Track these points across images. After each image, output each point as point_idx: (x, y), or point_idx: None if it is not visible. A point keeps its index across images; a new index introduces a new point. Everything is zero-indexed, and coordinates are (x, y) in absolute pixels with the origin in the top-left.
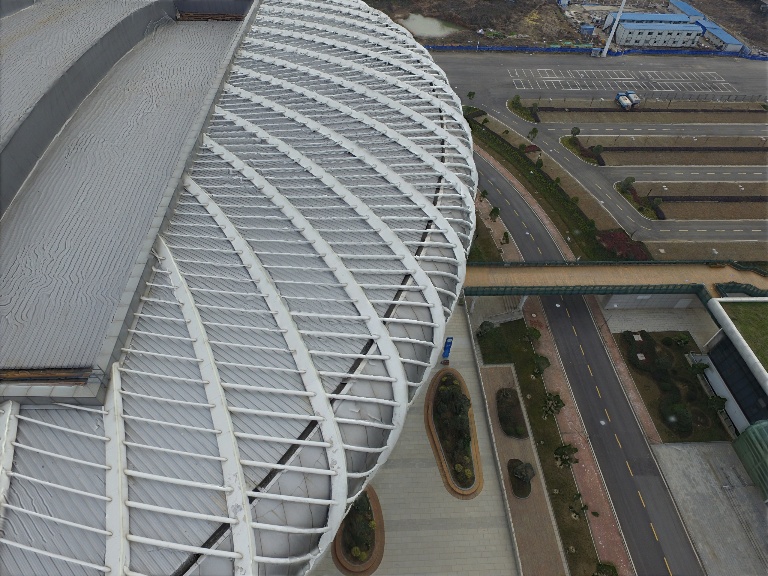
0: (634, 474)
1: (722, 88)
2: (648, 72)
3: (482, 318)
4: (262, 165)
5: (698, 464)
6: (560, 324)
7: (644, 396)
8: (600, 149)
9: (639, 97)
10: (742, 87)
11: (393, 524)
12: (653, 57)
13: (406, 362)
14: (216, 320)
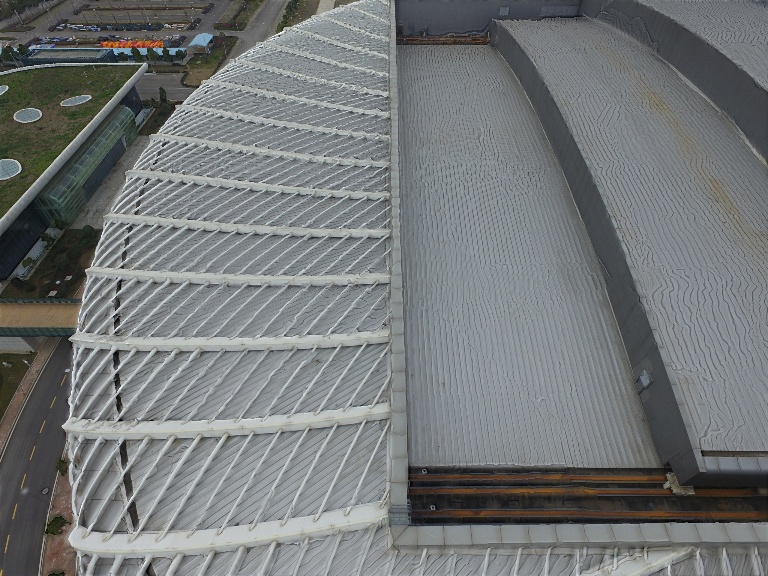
0: None
1: None
2: None
3: None
4: None
5: None
6: None
7: None
8: None
9: None
10: None
11: None
12: None
13: None
14: None
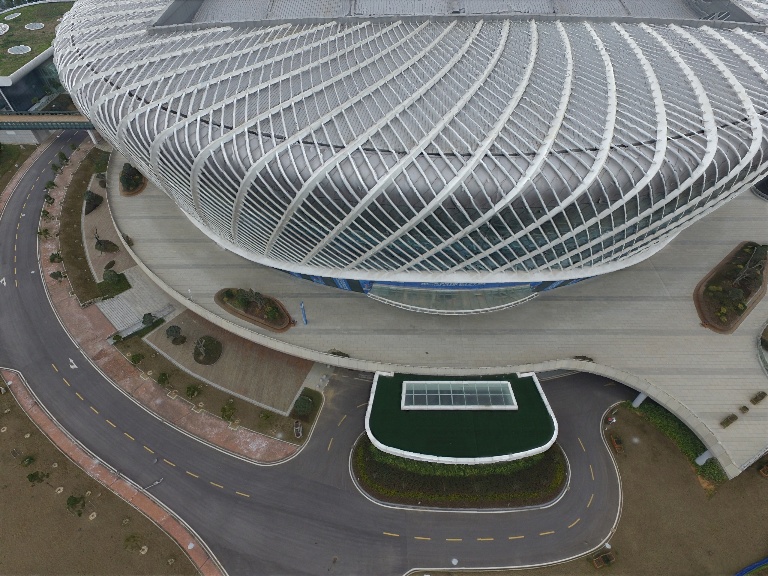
0: None
1: None
2: None
3: None
4: None
5: None
6: None
7: None
8: None
9: None
10: None
11: None
12: None
13: None
14: None
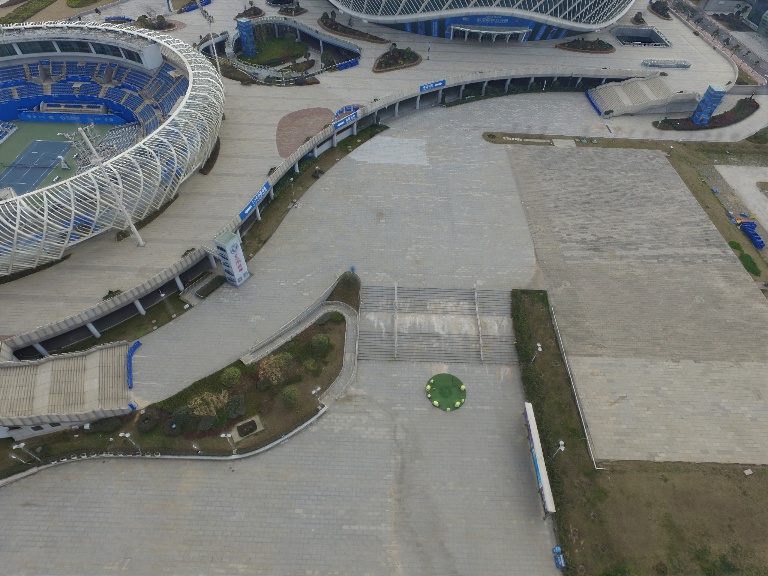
0: None
1: None
2: None
3: None
4: None
5: (744, 34)
6: None
7: (723, 24)
8: None
9: None
10: None
11: None
12: None
13: None
14: None
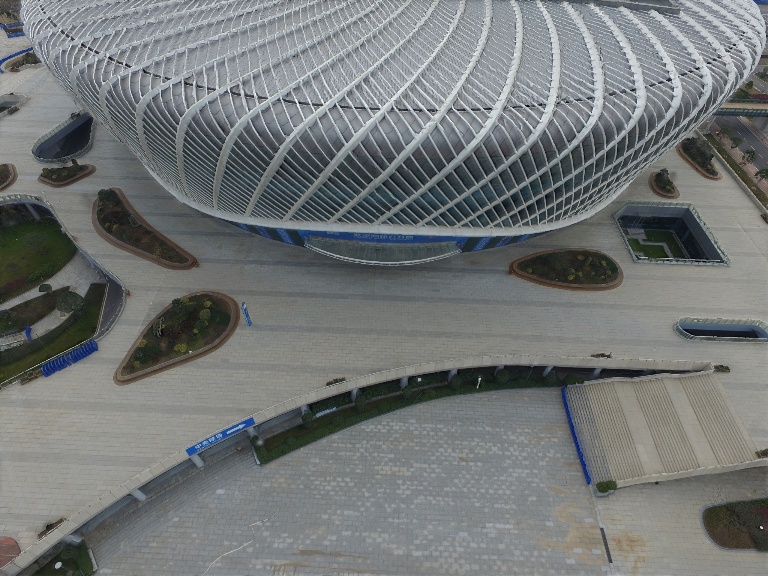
0: None
1: None
2: None
3: None
4: None
5: None
6: None
7: None
8: None
9: None
10: None
11: (680, 185)
12: (764, 6)
13: None
14: (695, 4)
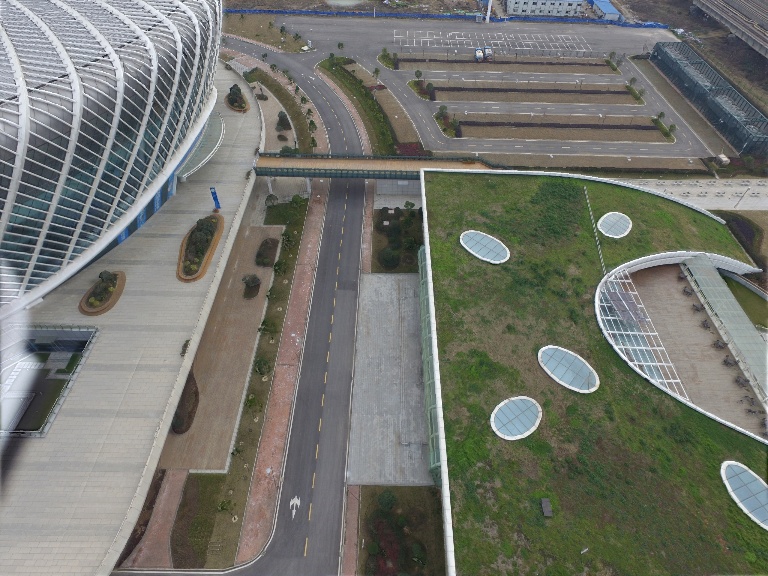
0: (338, 289)
1: (579, 48)
2: (519, 35)
3: (278, 197)
4: (7, 20)
5: (390, 285)
6: (336, 202)
7: (374, 246)
8: (430, 86)
9: (495, 52)
10: (598, 47)
11: (129, 292)
12: (532, 23)
13: (35, 109)
14: None
